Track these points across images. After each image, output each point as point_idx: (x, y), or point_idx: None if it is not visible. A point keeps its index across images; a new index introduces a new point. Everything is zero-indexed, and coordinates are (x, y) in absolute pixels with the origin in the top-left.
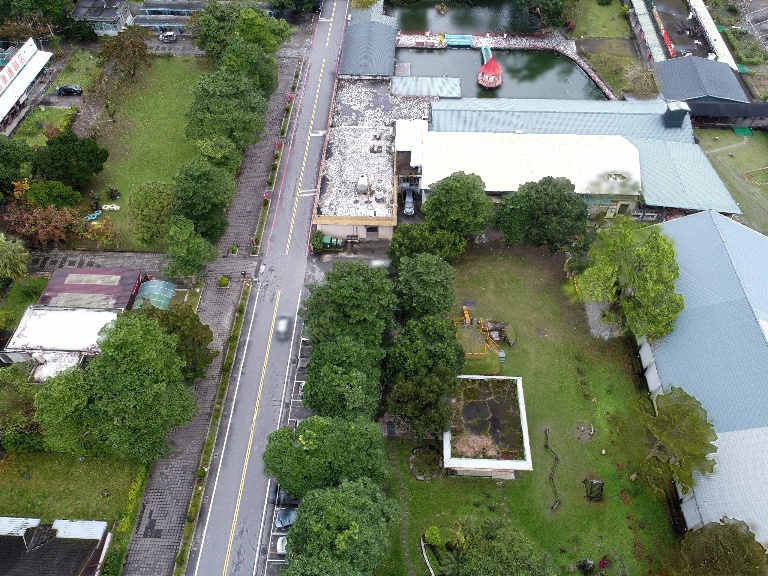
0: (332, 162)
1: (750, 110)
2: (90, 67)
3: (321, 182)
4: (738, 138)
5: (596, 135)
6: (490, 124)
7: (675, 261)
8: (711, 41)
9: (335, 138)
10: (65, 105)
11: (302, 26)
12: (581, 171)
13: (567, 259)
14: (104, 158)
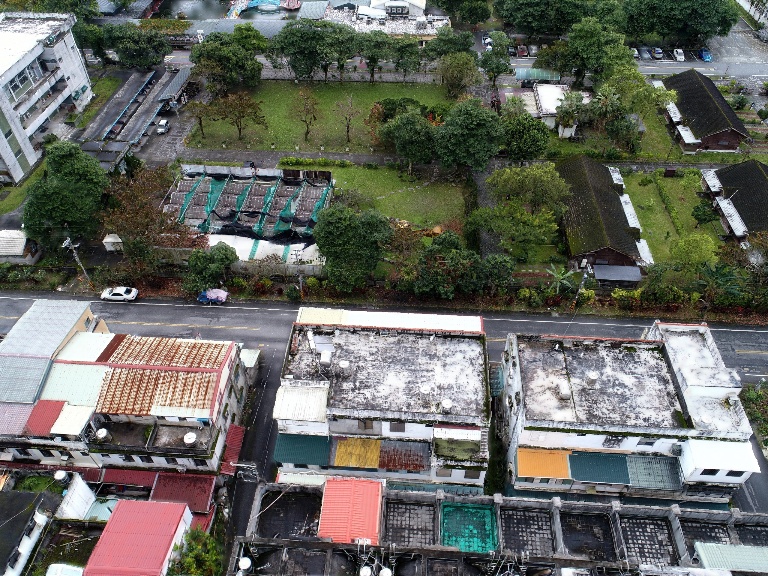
0: None
1: None
2: None
3: None
4: None
5: None
6: None
7: None
8: None
9: None
10: None
11: None
12: None
13: None
14: None
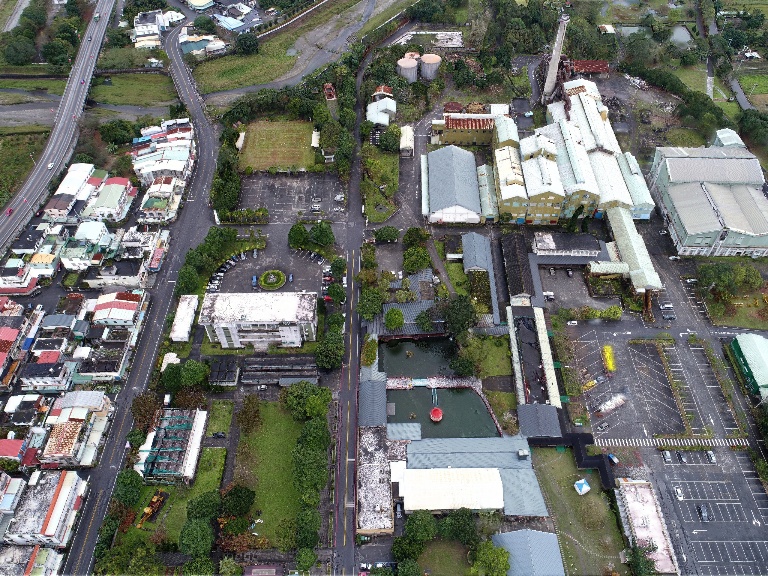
0: (362, 491)
1: (562, 441)
2: (225, 414)
3: (358, 505)
4: (558, 454)
5: (486, 468)
6: (436, 461)
7: (508, 563)
8: (548, 391)
9: (362, 474)
10: (218, 446)
11: (334, 372)
12: (477, 497)
13: (468, 552)
14: (254, 497)
